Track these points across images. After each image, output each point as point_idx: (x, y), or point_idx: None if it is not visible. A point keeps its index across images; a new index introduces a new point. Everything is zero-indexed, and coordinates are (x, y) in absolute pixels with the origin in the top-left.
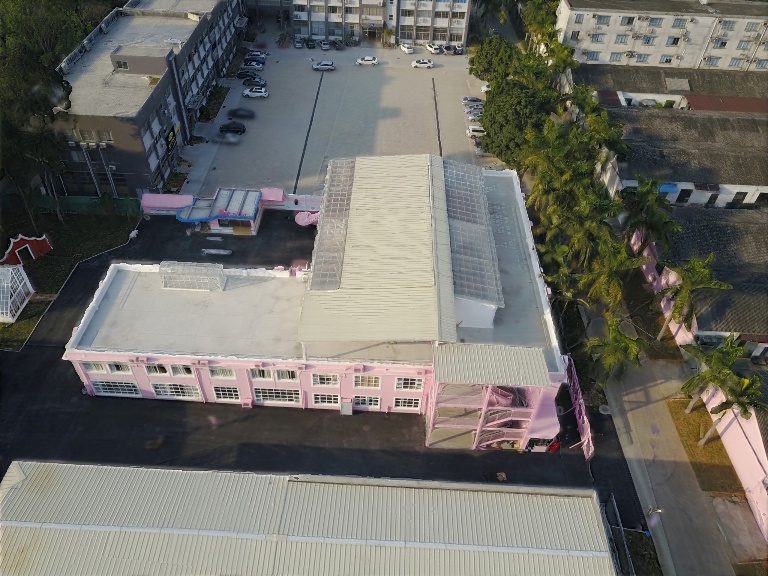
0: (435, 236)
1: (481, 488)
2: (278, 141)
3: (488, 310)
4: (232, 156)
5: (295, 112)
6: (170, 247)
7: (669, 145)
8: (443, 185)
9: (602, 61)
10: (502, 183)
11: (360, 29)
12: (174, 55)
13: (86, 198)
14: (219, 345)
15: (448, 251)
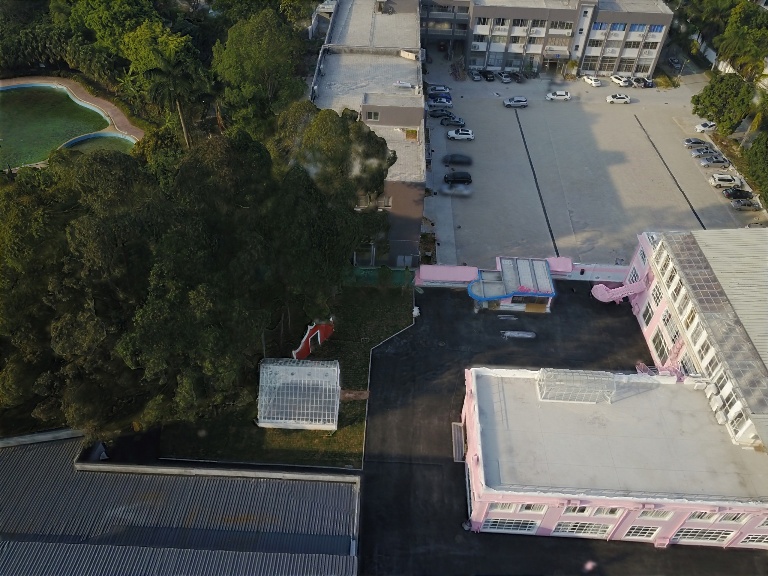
0: None
1: None
2: (510, 192)
3: None
4: (471, 211)
5: (510, 157)
6: (463, 328)
7: None
8: None
9: None
10: None
11: (541, 60)
12: None
13: (355, 269)
14: (649, 480)
15: None
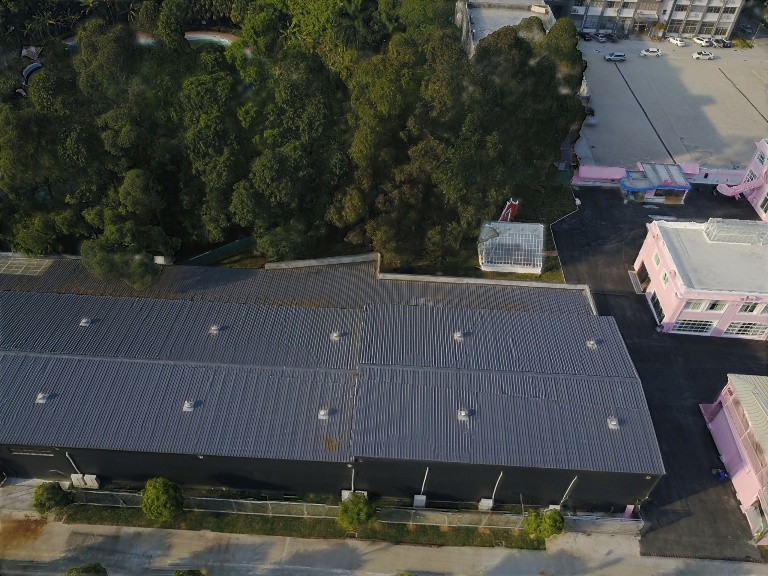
0: None
1: None
2: (627, 123)
3: None
4: (599, 136)
5: (620, 98)
6: (618, 213)
7: None
8: None
9: None
10: None
11: (631, 23)
12: None
13: None
14: None
15: None
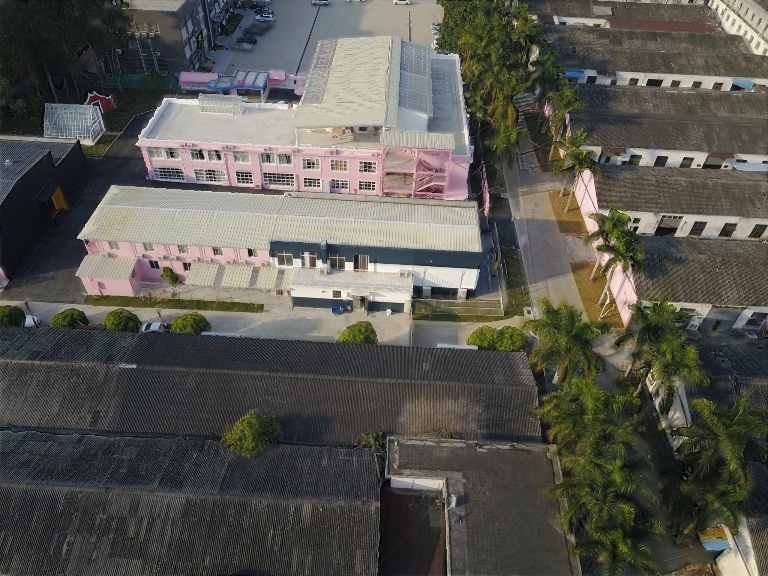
0: (389, 77)
1: (405, 201)
2: (282, 50)
3: (422, 120)
4: (246, 58)
5: (296, 32)
6: None
7: (582, 46)
8: (399, 53)
9: None
10: (447, 63)
11: None
12: None
13: (138, 75)
14: (240, 140)
15: (397, 85)
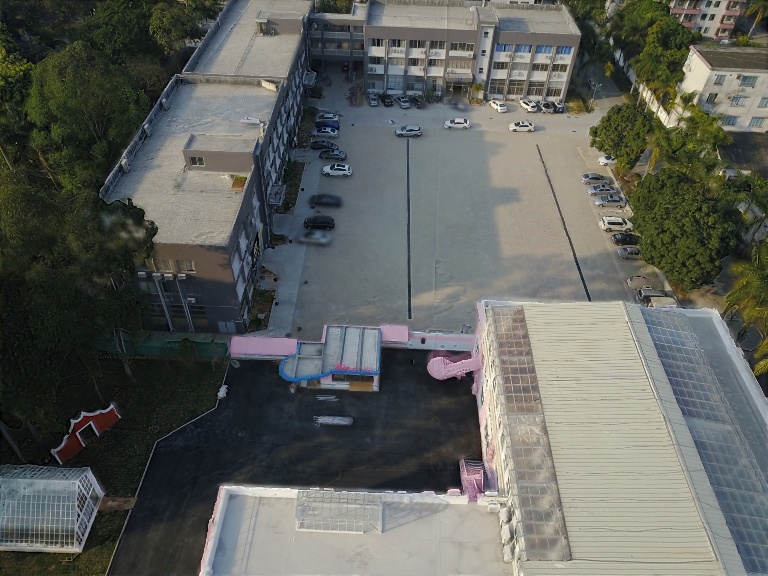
0: (682, 456)
1: None
2: (375, 238)
3: None
4: (324, 263)
5: (387, 195)
6: (272, 413)
7: None
8: (656, 355)
9: (739, 126)
10: (702, 328)
11: (444, 83)
12: (260, 147)
13: (159, 341)
14: None
15: (707, 484)
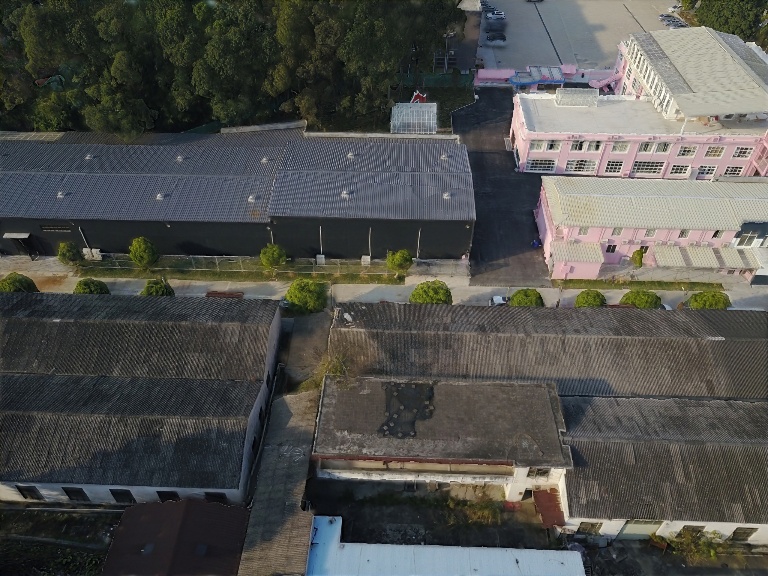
0: (741, 66)
1: None
2: (533, 46)
3: None
4: (507, 55)
5: (532, 28)
6: (507, 103)
7: None
8: None
9: None
10: None
11: None
12: None
13: (436, 74)
14: (617, 131)
15: (754, 73)
